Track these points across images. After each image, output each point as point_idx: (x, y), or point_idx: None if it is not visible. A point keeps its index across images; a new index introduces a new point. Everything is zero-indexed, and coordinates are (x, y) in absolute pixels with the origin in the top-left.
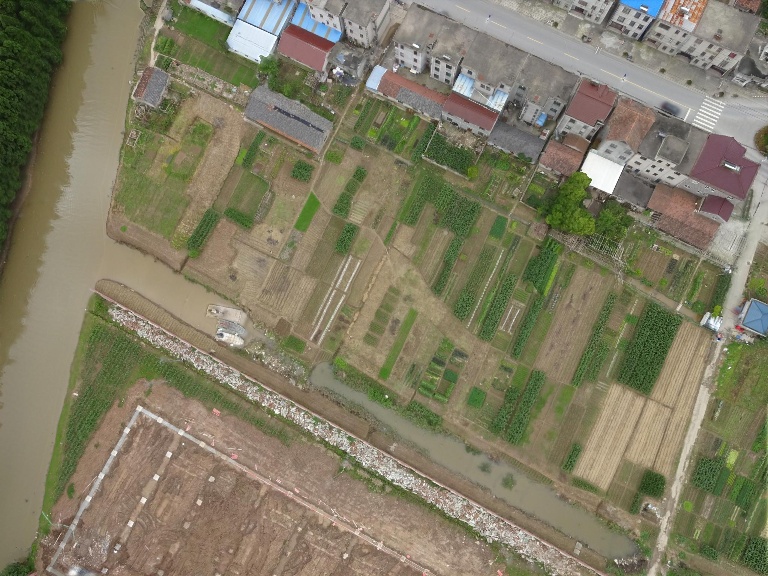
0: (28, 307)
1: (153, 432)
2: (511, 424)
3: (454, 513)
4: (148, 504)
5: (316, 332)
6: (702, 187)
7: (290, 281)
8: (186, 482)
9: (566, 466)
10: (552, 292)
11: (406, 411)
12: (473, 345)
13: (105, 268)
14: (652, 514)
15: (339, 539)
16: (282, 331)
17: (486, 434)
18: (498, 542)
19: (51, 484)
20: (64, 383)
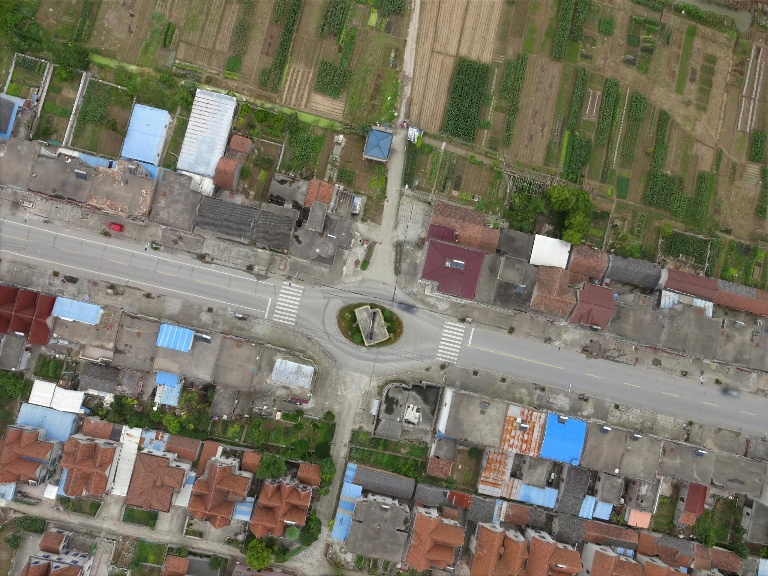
0: None
1: None
2: (574, 8)
3: None
4: None
5: (759, 56)
6: None
7: None
8: None
9: None
10: (561, 136)
11: (665, 2)
12: (620, 73)
13: None
14: None
15: None
16: None
17: None
18: None
19: None
20: None
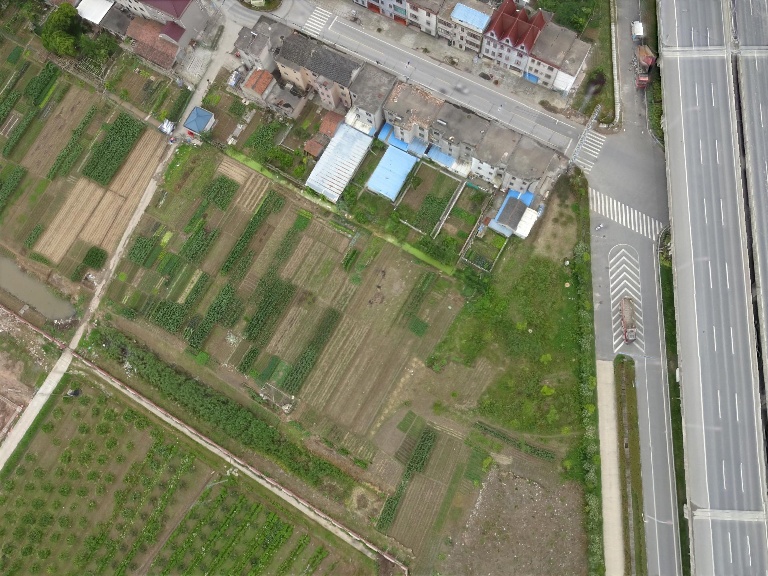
0: None
1: None
2: None
3: None
4: None
5: None
6: (157, 13)
7: None
8: None
9: (27, 241)
10: (47, 105)
11: None
12: None
13: None
14: (91, 282)
15: None
16: None
17: None
18: None
19: None
20: None
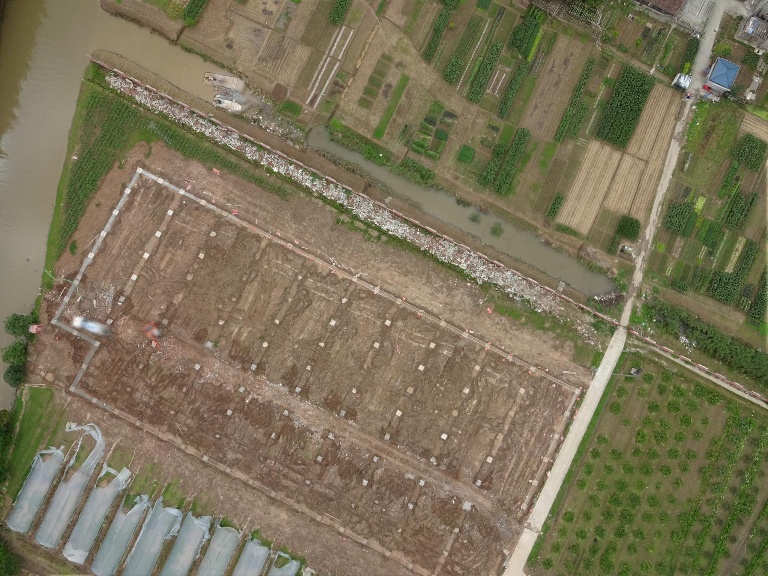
0: (19, 99)
1: (154, 192)
2: (499, 176)
3: (446, 257)
4: (151, 258)
5: (312, 96)
6: None
7: (285, 49)
8: (188, 237)
9: (550, 213)
10: (535, 58)
11: (400, 167)
12: (462, 107)
13: (100, 40)
14: (628, 254)
15: (338, 285)
16: (279, 96)
17: (475, 186)
18: (488, 282)
19: (53, 243)
20: (62, 149)
